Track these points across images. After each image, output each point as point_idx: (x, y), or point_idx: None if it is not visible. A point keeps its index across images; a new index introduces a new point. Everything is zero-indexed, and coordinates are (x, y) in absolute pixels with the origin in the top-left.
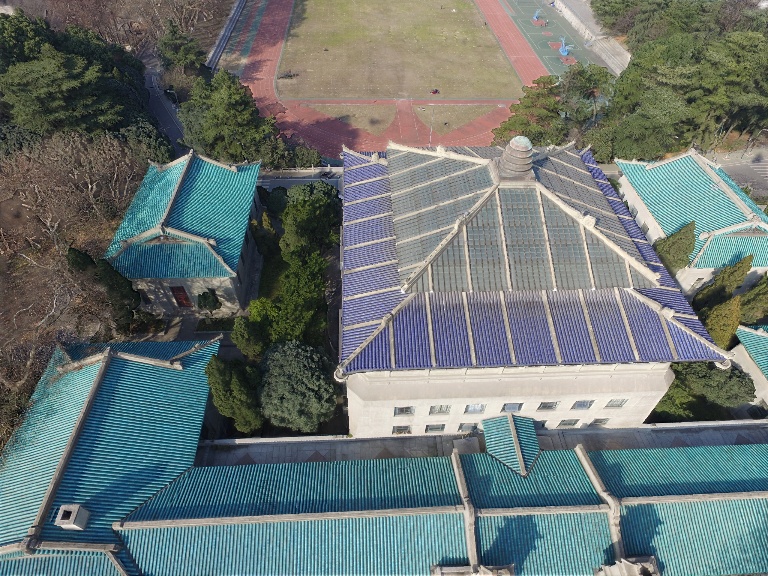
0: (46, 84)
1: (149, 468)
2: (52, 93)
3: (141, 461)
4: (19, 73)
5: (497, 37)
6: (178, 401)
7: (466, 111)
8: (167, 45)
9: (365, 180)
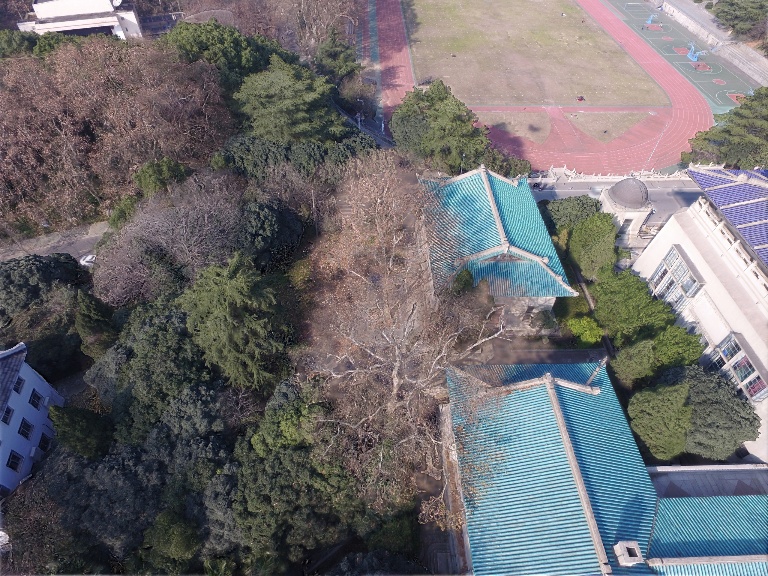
0: (292, 96)
1: (633, 499)
2: (297, 105)
3: (624, 492)
4: (263, 85)
5: (618, 42)
6: (612, 428)
7: (620, 119)
8: (327, 52)
9: (745, 201)
